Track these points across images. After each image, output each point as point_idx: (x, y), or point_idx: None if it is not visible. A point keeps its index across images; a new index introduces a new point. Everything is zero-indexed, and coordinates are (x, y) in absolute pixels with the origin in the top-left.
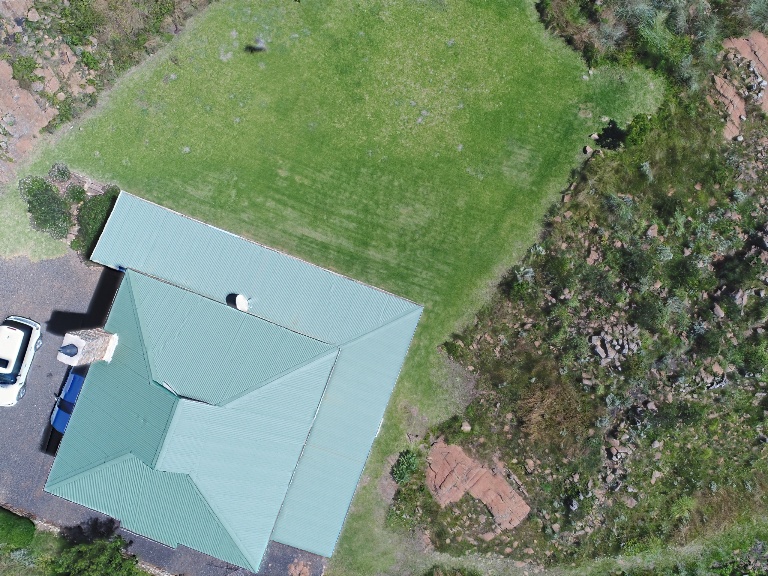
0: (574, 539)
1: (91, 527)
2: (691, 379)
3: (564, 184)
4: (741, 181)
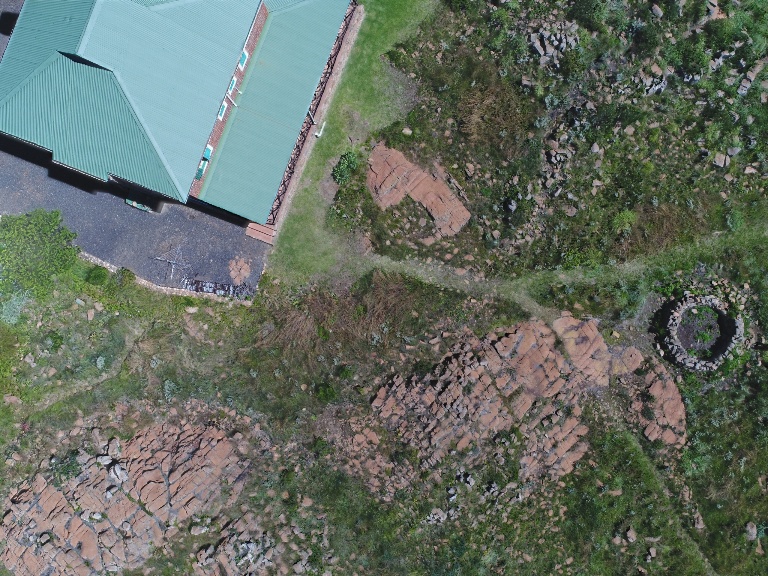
0: (515, 250)
1: None
2: (630, 80)
3: None
4: None
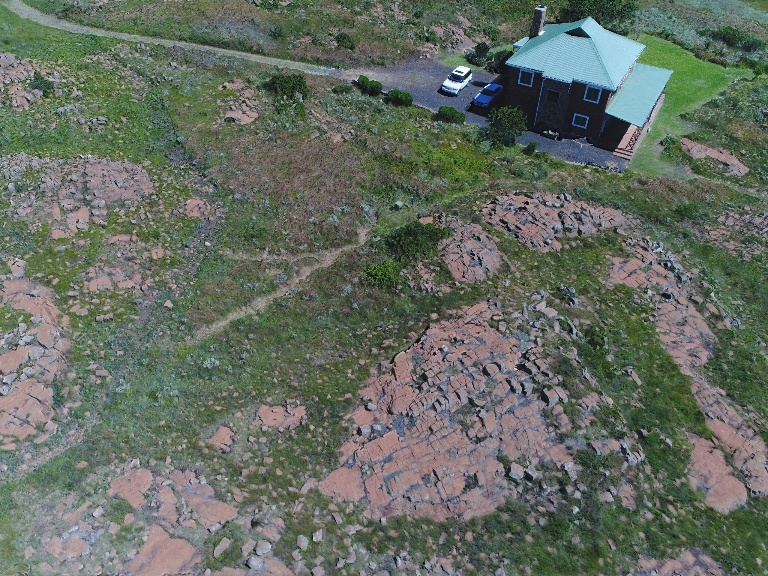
0: None
1: None
2: None
3: None
4: None
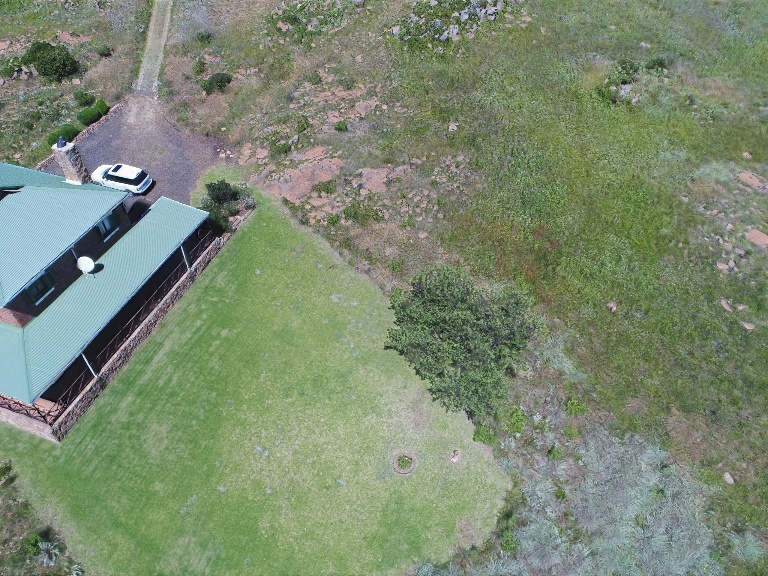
0: None
1: None
2: None
3: None
4: None
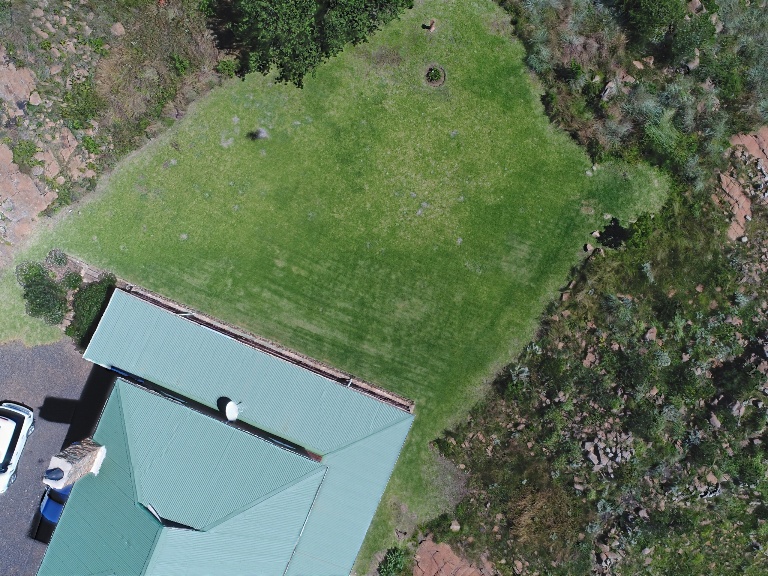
0: None
1: None
2: (684, 488)
3: (563, 282)
4: (744, 284)
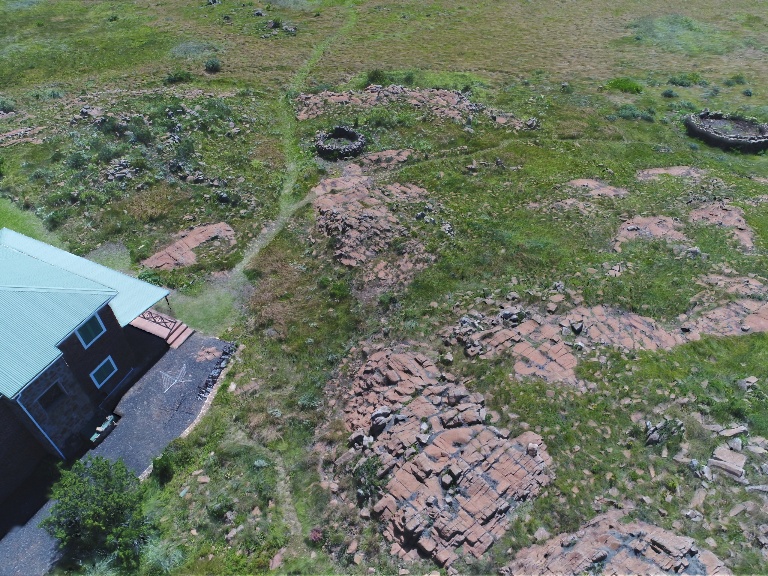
0: None
1: (62, 550)
2: None
3: (7, 201)
4: None
